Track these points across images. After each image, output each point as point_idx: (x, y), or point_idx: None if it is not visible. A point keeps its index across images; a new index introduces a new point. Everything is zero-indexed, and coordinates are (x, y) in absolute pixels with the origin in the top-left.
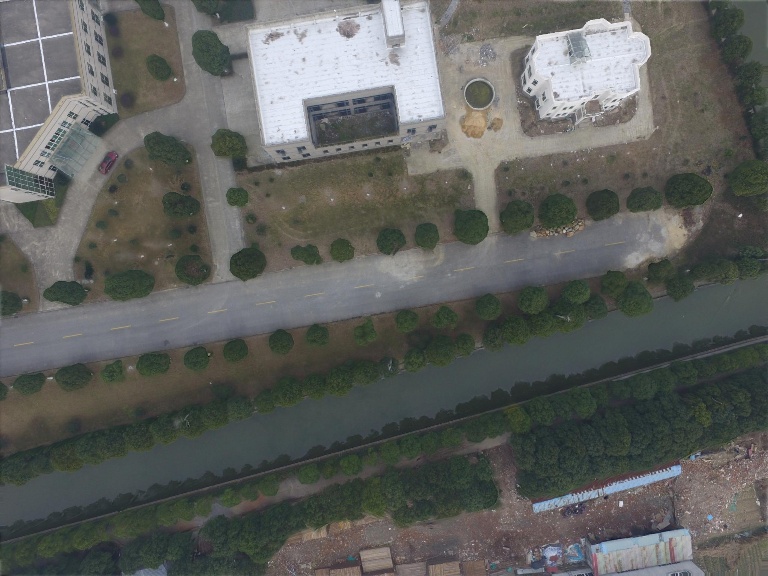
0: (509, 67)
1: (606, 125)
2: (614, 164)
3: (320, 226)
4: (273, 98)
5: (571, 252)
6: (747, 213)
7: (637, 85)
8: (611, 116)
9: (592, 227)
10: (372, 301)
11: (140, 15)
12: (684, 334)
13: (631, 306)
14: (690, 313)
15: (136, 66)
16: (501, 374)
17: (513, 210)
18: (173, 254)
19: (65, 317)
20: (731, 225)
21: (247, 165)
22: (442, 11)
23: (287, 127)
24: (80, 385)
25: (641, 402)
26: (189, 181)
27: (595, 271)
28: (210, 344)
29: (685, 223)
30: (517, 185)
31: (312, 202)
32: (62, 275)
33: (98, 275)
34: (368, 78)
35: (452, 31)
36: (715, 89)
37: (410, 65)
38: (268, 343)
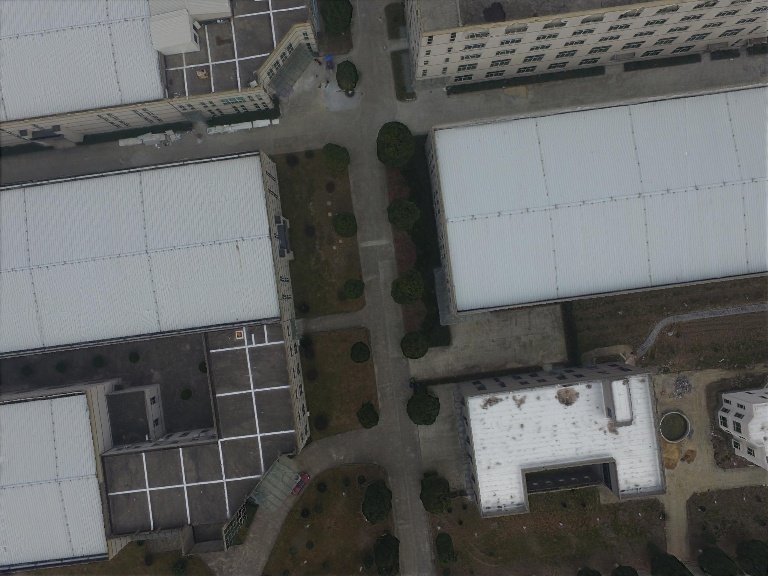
0: (704, 399)
1: None
2: None
3: (511, 552)
4: (490, 463)
5: None
6: None
7: None
8: None
9: None
10: None
11: (335, 337)
12: None
13: None
14: None
15: (331, 389)
16: None
17: None
18: None
19: None
20: None
21: None
22: (639, 343)
23: (503, 492)
24: None
25: None
26: None
27: None
28: None
29: None
30: (709, 518)
31: (504, 529)
32: None
33: None
34: (586, 446)
35: (649, 363)
36: None
37: (628, 435)
38: None
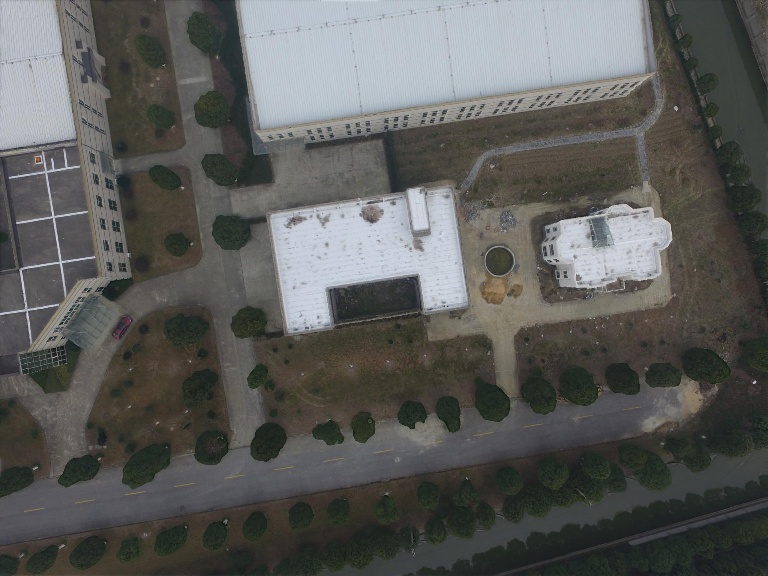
0: (529, 234)
1: (624, 292)
2: (632, 331)
3: (339, 392)
4: (295, 283)
5: (589, 417)
6: (761, 381)
7: (658, 270)
8: (629, 283)
9: (610, 392)
10: (391, 466)
11: None
12: (697, 488)
13: (650, 485)
14: (704, 475)
15: (151, 230)
16: (518, 531)
17: (536, 397)
18: (189, 420)
19: (77, 482)
20: (745, 392)
21: (265, 331)
22: (463, 177)
23: (310, 312)
24: (95, 563)
25: (659, 575)
26: (206, 346)
27: (613, 435)
28: (227, 510)
29: (701, 388)
30: (536, 352)
31: (331, 368)
32: (74, 440)
33: (111, 441)
34: (392, 264)
35: (473, 197)
36: (731, 257)
37: (434, 251)
38: (286, 509)
